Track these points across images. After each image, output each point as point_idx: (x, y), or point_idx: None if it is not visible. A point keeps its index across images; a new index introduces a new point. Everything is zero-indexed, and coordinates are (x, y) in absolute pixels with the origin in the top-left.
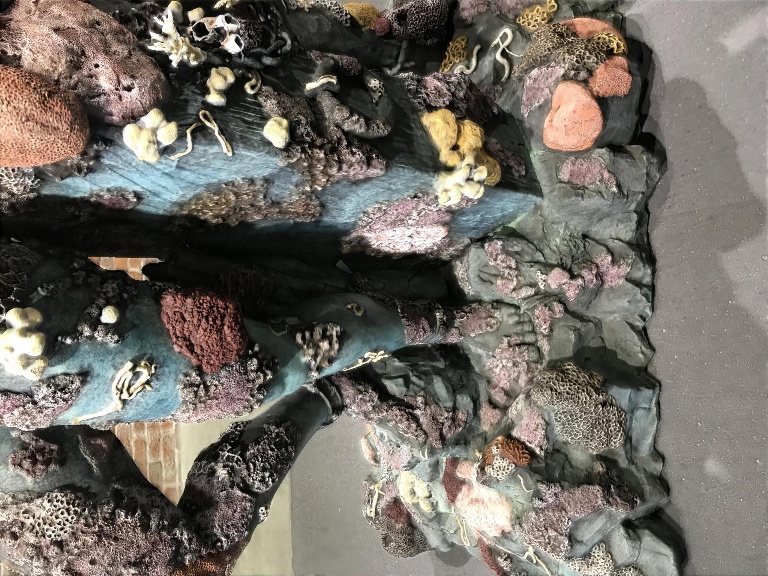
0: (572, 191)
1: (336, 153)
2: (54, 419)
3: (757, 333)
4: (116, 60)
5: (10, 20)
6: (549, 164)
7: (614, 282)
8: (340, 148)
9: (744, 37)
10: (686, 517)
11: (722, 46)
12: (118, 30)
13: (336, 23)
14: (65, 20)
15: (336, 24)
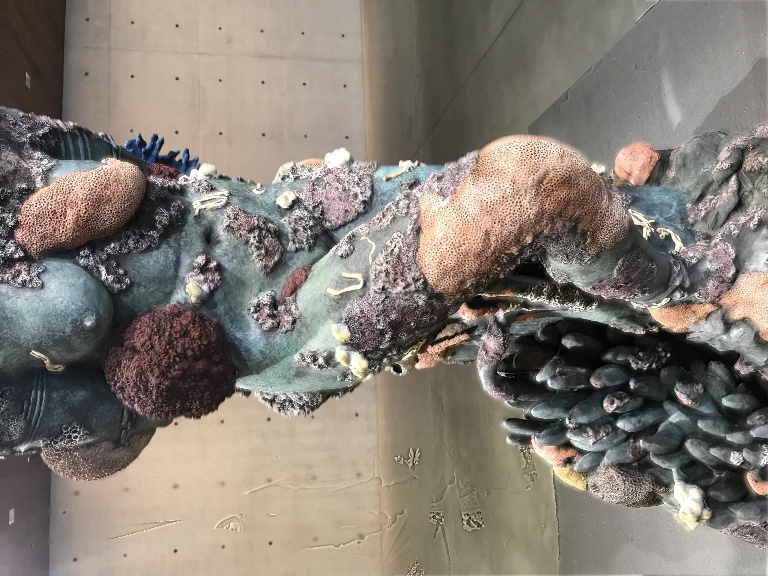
0: None
1: None
2: (372, 177)
3: None
4: None
5: None
6: None
7: (764, 131)
8: None
9: (676, 114)
10: None
11: (677, 126)
12: None
13: None
14: None
15: None
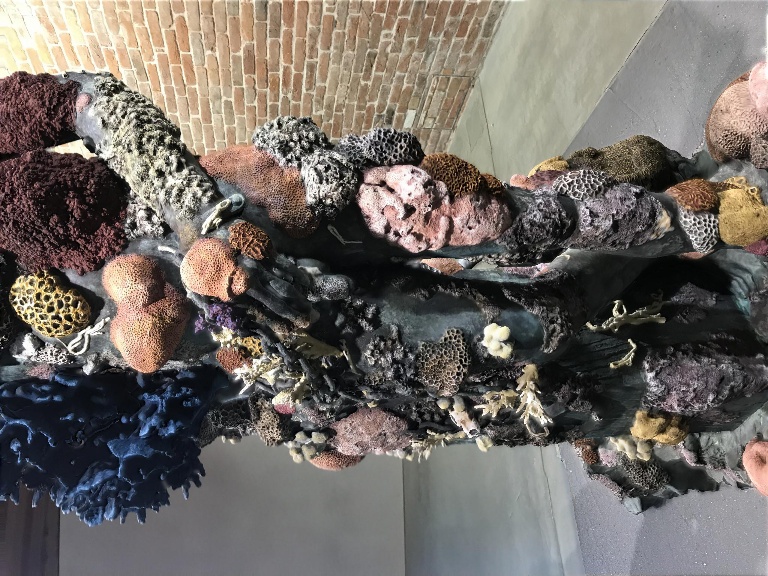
0: (735, 465)
1: None
2: None
3: (762, 561)
4: (387, 447)
5: (335, 435)
6: (752, 435)
7: (729, 476)
8: (530, 442)
9: None
10: (670, 507)
11: None
12: (395, 430)
13: (691, 245)
14: (364, 437)
15: (690, 246)
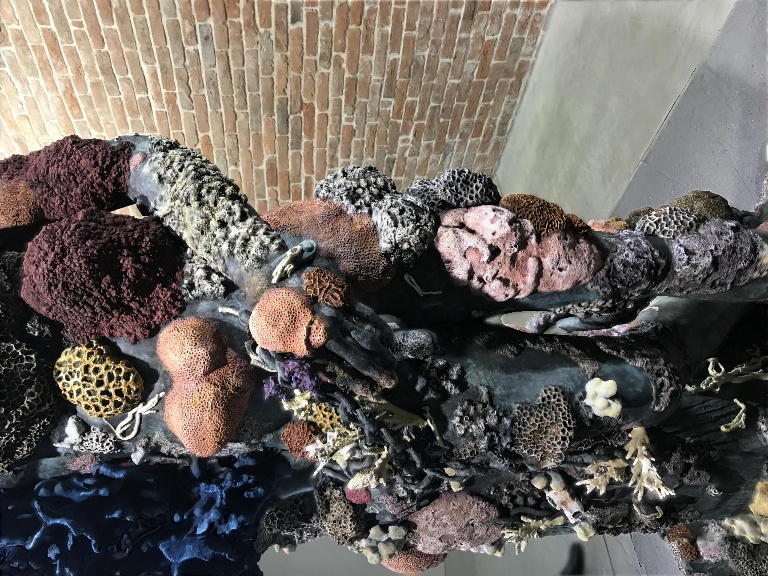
0: None
1: (630, 531)
2: None
3: None
4: (475, 541)
5: (415, 529)
6: None
7: None
8: (636, 528)
9: None
10: None
11: None
12: None
13: None
14: (449, 529)
15: None
